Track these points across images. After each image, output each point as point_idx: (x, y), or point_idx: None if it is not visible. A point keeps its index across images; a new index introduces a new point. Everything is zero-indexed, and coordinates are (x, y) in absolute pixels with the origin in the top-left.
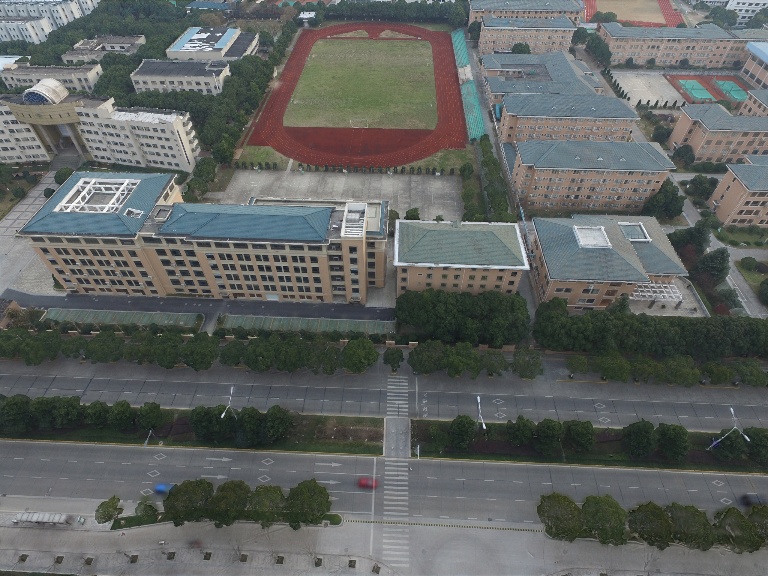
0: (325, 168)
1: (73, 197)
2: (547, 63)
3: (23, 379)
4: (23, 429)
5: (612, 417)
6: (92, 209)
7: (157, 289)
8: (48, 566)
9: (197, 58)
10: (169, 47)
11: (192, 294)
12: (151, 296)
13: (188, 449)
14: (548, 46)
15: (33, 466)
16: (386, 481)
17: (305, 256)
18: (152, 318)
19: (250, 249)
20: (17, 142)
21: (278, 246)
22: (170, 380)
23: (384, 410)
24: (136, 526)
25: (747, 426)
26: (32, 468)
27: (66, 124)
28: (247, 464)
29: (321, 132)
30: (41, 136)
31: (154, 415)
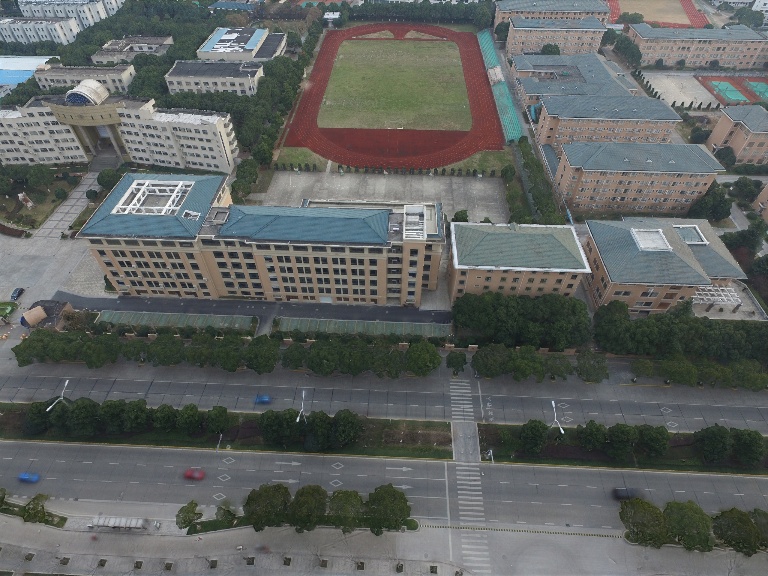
0: (365, 169)
1: (128, 199)
2: (579, 64)
3: (83, 382)
4: (91, 433)
5: (680, 421)
6: (148, 211)
7: (210, 291)
8: (128, 571)
9: (228, 59)
10: (199, 48)
11: (244, 296)
12: (203, 298)
13: (256, 453)
14: (577, 47)
15: (102, 470)
16: (459, 486)
17: (365, 259)
18: (206, 320)
19: (310, 252)
20: (56, 143)
21: (338, 249)
22: (231, 383)
23: (449, 414)
24: (212, 531)
25: None
26: (101, 472)
27: (107, 125)
28: (317, 468)
29: (357, 133)
30: (80, 137)
31: (223, 419)
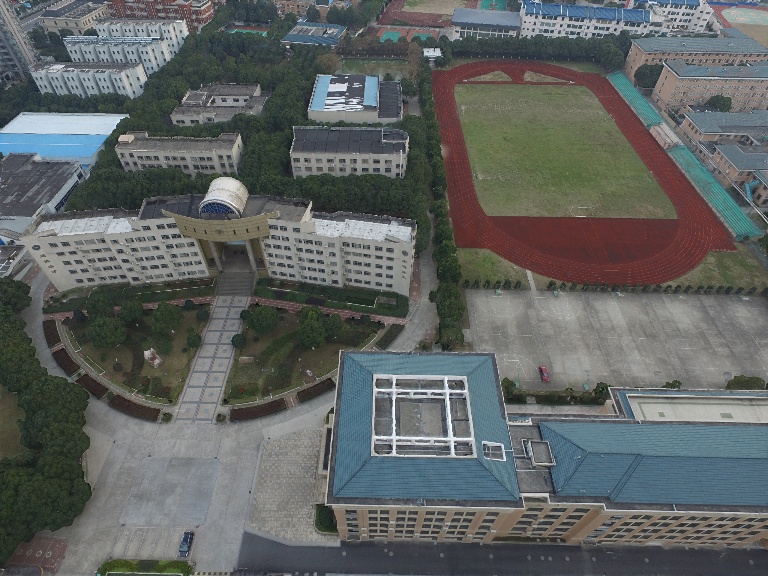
0: (585, 287)
1: None
2: None
3: None
4: None
5: None
6: None
7: (486, 537)
8: None
9: (345, 119)
10: (309, 105)
11: (531, 537)
12: (469, 542)
13: None
14: (747, 98)
15: None
16: None
17: None
18: None
19: None
20: (173, 259)
21: None
22: None
23: None
24: None
25: None
26: None
27: None
28: None
29: (540, 225)
30: (204, 249)
31: None
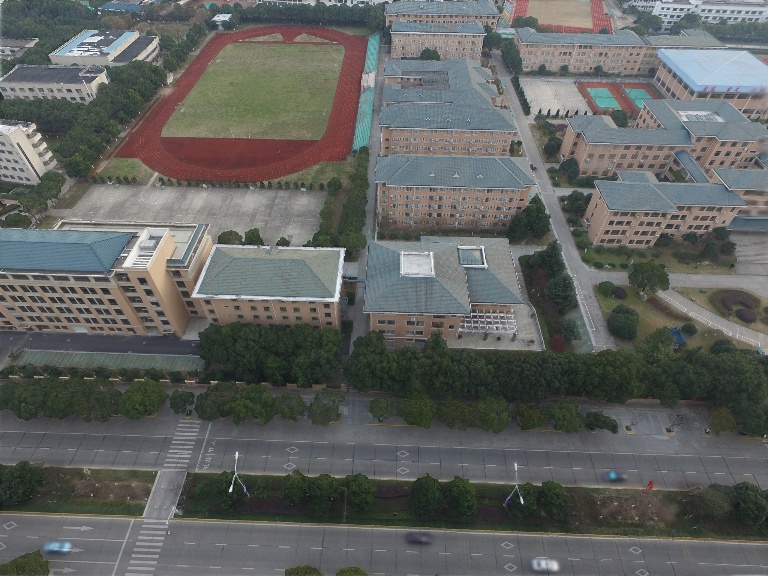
0: (187, 183)
1: None
2: (450, 70)
3: None
4: None
5: (412, 467)
6: None
7: None
8: None
9: (83, 63)
10: (54, 51)
11: None
12: None
13: None
14: (459, 52)
15: None
16: (136, 548)
17: (94, 287)
18: None
19: (31, 280)
20: None
21: (61, 277)
22: None
23: (162, 461)
24: None
25: (557, 476)
26: None
27: None
28: None
29: (198, 143)
30: None
31: None
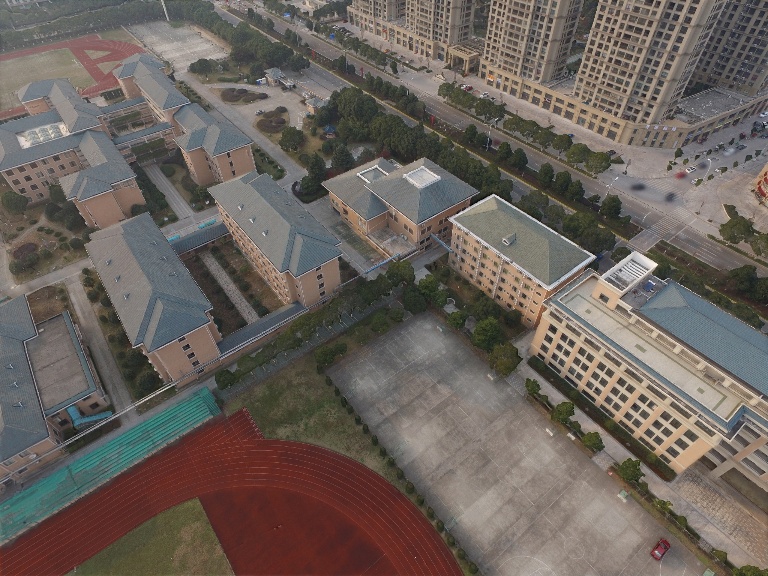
0: None
1: None
2: None
3: None
4: None
5: None
6: None
7: None
8: None
9: None
10: None
11: None
12: None
13: None
14: None
15: None
16: (668, 231)
17: None
18: None
19: None
20: None
21: None
22: None
23: None
24: None
25: None
26: None
27: None
28: None
29: None
30: None
31: None
